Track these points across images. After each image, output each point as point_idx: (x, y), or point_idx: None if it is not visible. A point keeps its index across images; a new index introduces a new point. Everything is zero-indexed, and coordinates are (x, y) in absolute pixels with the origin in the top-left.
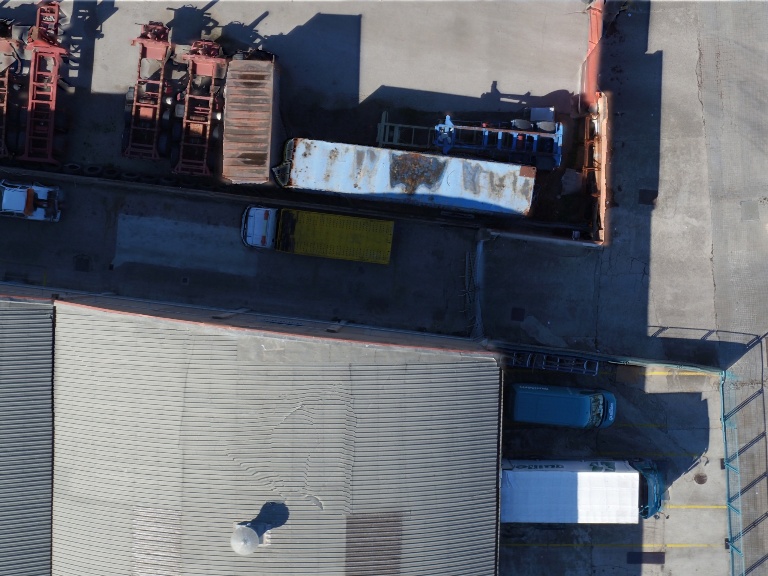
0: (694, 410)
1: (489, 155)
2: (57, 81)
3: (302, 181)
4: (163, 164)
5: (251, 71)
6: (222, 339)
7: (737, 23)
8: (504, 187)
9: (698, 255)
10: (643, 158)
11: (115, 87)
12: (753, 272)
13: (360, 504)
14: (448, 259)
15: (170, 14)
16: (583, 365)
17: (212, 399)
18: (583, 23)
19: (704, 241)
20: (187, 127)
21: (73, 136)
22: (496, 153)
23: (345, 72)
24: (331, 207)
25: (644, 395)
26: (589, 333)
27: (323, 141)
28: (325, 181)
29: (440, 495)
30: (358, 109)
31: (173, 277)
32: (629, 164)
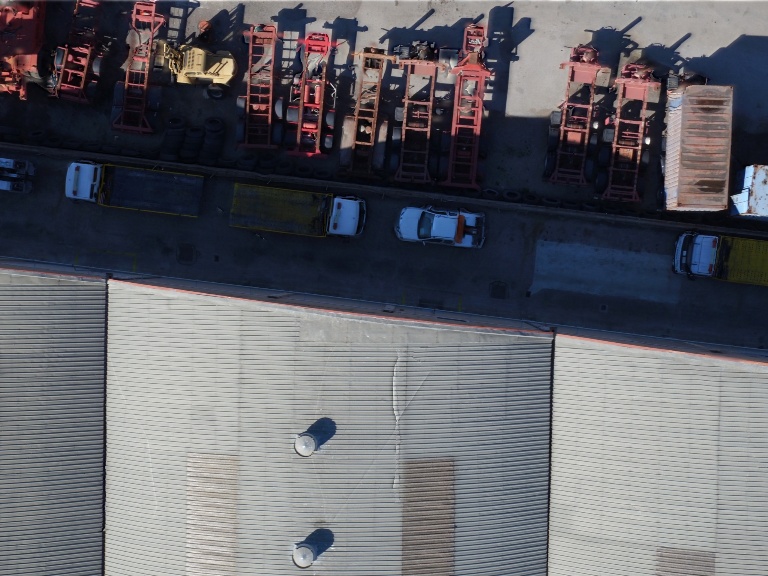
0: None
1: None
2: (482, 105)
3: (762, 209)
4: (585, 189)
5: (709, 96)
6: (762, 377)
7: None
8: None
9: None
10: None
11: (530, 111)
12: None
13: None
14: None
15: (588, 36)
16: None
17: (751, 438)
18: None
19: None
20: (616, 152)
21: (489, 161)
22: None
23: None
24: None
25: None
26: None
27: None
28: None
29: None
30: None
31: (592, 304)
32: None
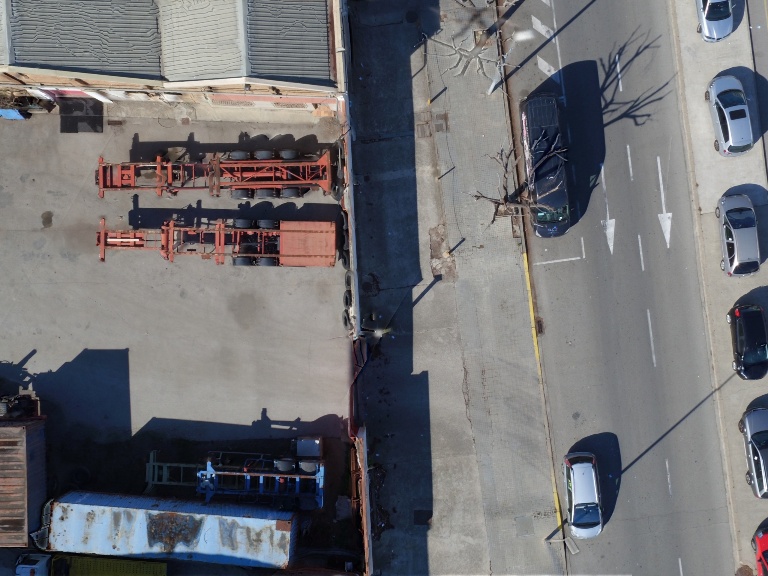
0: None
1: (251, 500)
2: None
3: (61, 545)
4: None
5: (4, 438)
6: None
7: (500, 340)
8: (261, 542)
9: (477, 572)
10: (416, 479)
11: None
12: None
13: None
14: None
15: None
16: None
17: None
18: (347, 349)
19: (481, 558)
20: None
21: None
22: (259, 496)
23: (116, 406)
24: None
25: None
26: None
27: (79, 504)
28: (84, 544)
29: None
30: (131, 442)
31: None
32: (402, 485)
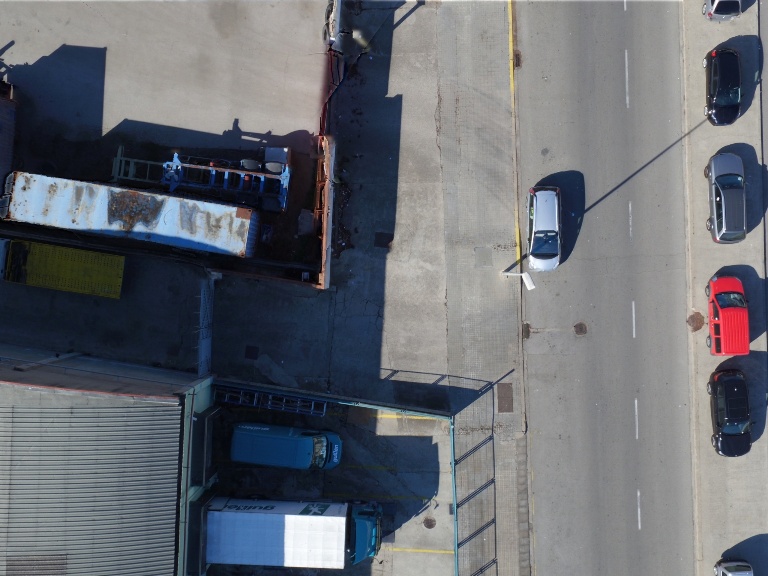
0: (424, 453)
1: (214, 194)
2: None
3: (20, 215)
4: None
5: None
6: None
7: (476, 70)
8: (220, 228)
9: (432, 299)
10: (380, 201)
11: None
12: (483, 318)
13: (16, 546)
14: (184, 295)
15: None
16: (311, 406)
17: None
18: (324, 64)
19: (438, 286)
20: None
21: None
22: (223, 192)
23: (89, 104)
24: (61, 240)
25: (374, 437)
26: (322, 373)
27: (42, 175)
28: (43, 215)
29: (97, 540)
30: (101, 141)
31: None
32: (366, 206)
